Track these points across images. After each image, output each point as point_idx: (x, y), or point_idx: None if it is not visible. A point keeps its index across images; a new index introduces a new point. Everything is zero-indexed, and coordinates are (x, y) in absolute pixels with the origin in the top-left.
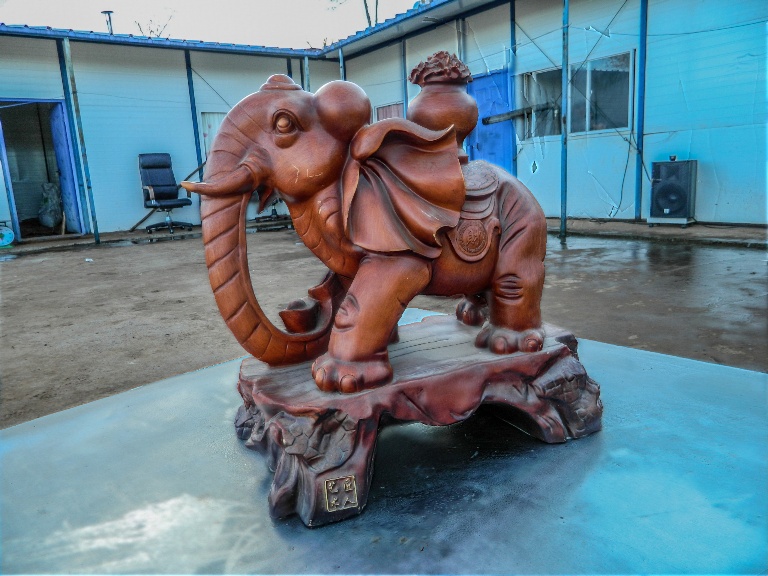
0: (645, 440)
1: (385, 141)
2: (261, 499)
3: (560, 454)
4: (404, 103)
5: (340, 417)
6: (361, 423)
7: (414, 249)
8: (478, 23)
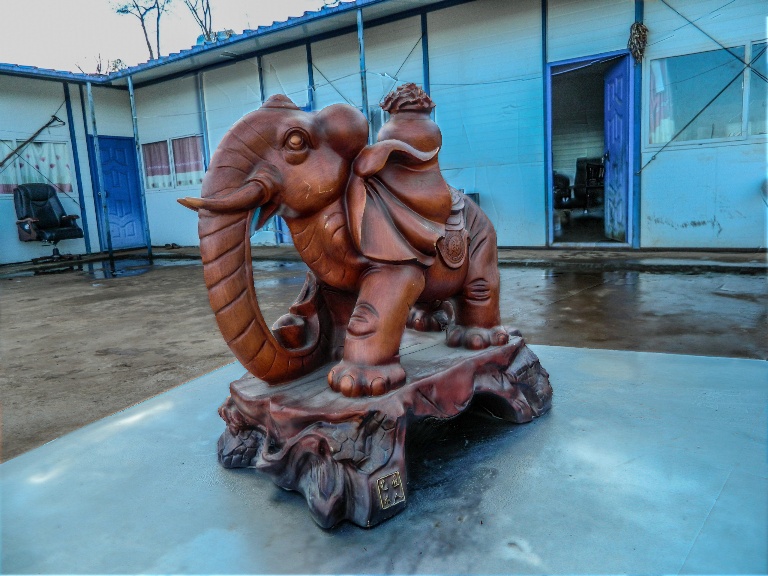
0: (589, 409)
1: (387, 160)
2: (297, 516)
3: (535, 430)
4: (204, 136)
5: (379, 418)
6: (398, 421)
7: None
8: (279, 62)
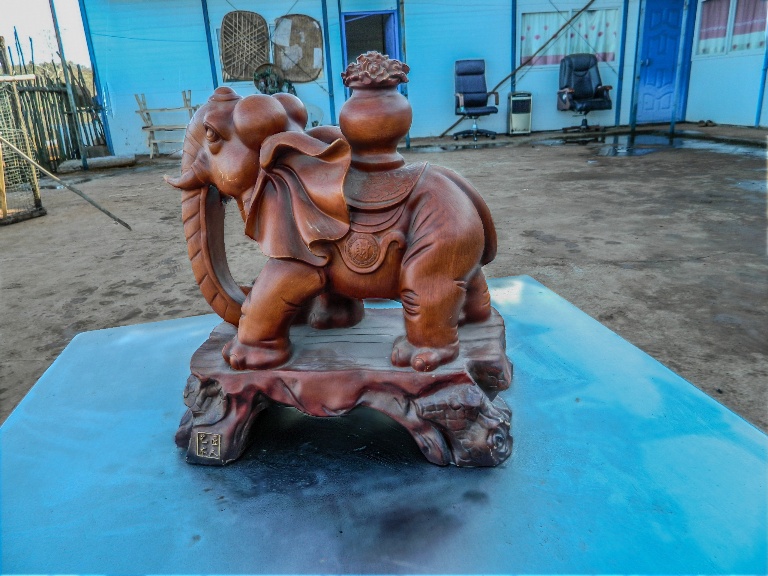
0: (519, 494)
1: (279, 153)
2: None
3: (423, 476)
4: None
5: (218, 387)
6: (230, 396)
7: (298, 256)
8: None
